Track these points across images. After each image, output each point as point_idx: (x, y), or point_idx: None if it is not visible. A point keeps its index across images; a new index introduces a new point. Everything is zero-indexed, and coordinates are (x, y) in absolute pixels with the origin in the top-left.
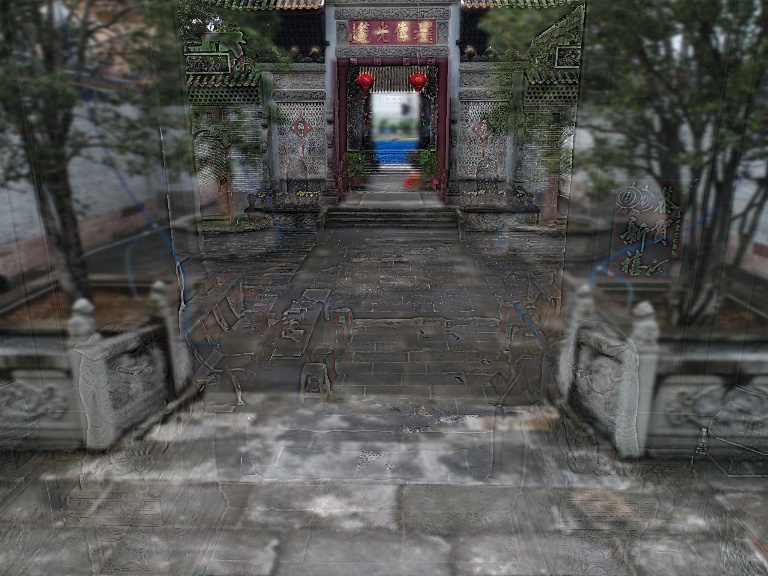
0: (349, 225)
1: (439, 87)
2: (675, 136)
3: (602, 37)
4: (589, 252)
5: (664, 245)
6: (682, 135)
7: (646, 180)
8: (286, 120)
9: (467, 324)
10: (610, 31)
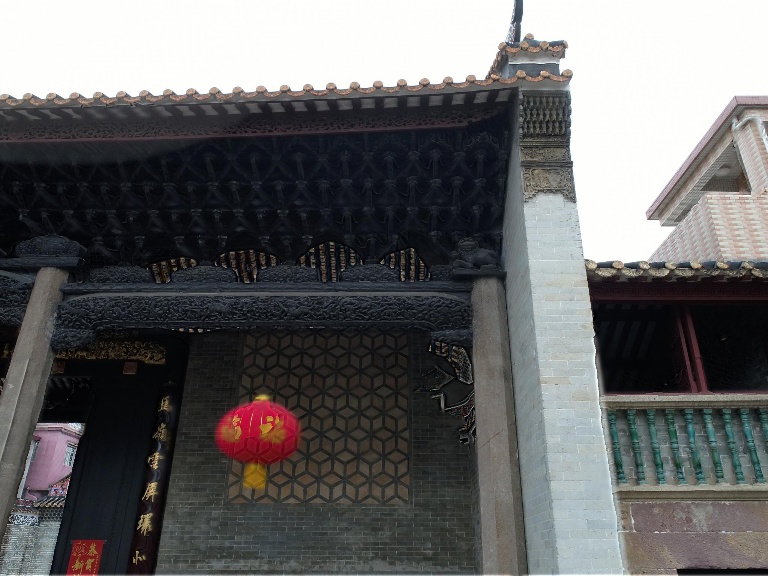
0: None
1: None
2: (99, 521)
3: (74, 482)
4: (57, 575)
5: (90, 571)
6: (102, 521)
7: (85, 540)
8: None
9: None
10: (78, 480)
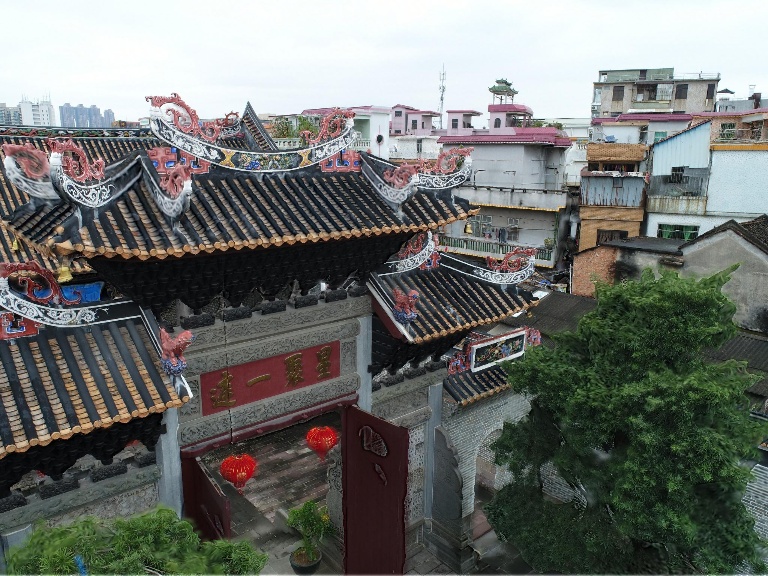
0: (266, 547)
1: None
2: None
3: None
4: None
5: None
6: None
7: None
8: (412, 448)
9: (69, 469)
10: None
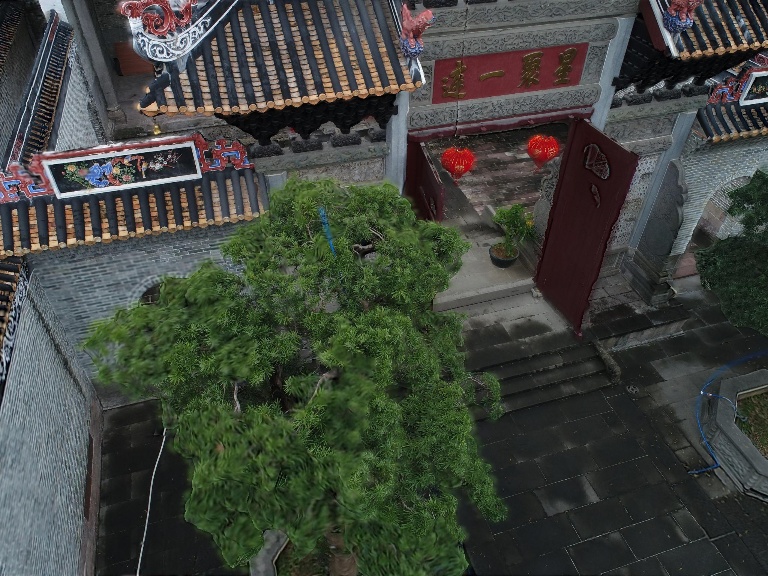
0: (471, 235)
1: None
2: None
3: None
4: None
5: None
6: None
7: None
8: (638, 177)
9: None
10: None
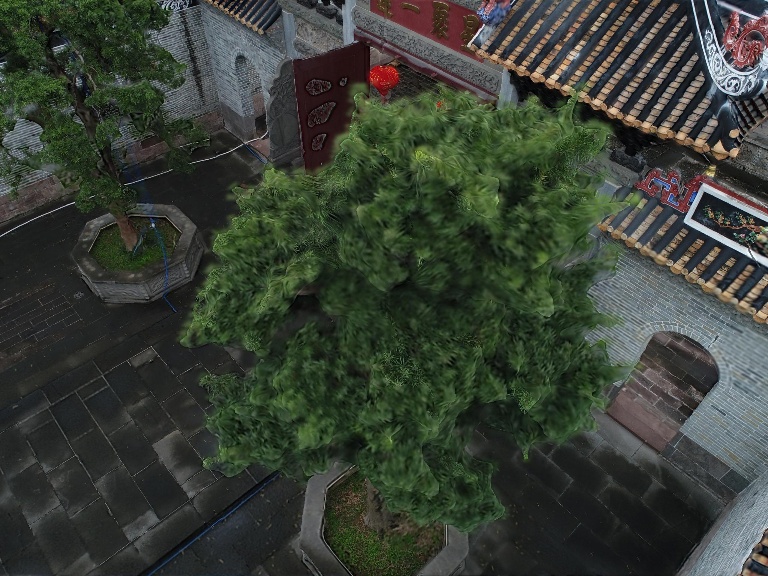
0: None
1: (369, 72)
2: None
3: None
4: None
5: None
6: None
7: None
8: None
9: None
10: None
